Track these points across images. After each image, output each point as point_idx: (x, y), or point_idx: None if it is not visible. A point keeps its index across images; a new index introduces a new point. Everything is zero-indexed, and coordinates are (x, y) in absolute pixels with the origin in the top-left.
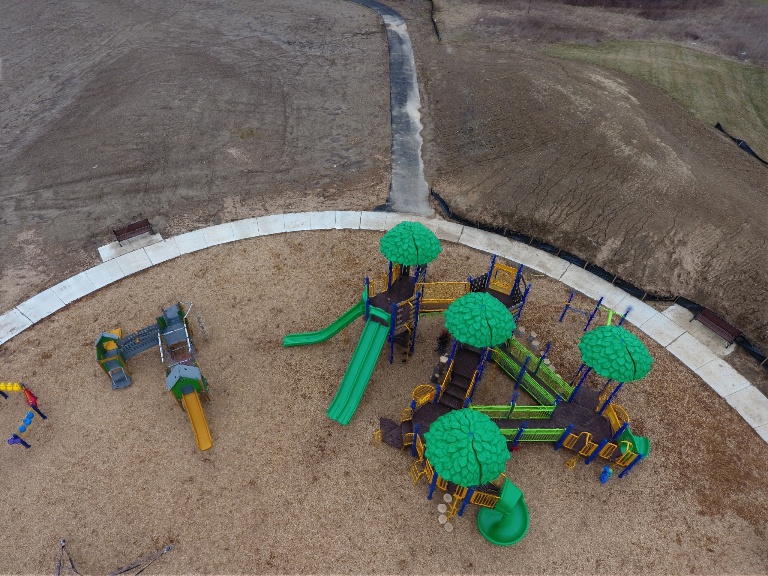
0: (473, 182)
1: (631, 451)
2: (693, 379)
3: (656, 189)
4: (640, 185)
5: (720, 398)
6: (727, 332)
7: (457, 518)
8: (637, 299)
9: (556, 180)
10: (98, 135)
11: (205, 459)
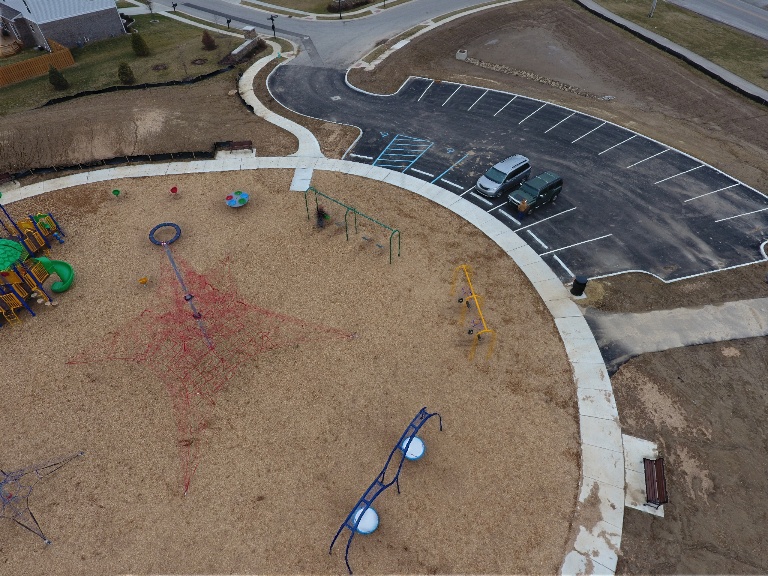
0: None
1: (46, 218)
2: (26, 200)
3: None
4: None
5: (43, 194)
6: (4, 179)
7: None
8: None
9: None
10: None
11: None
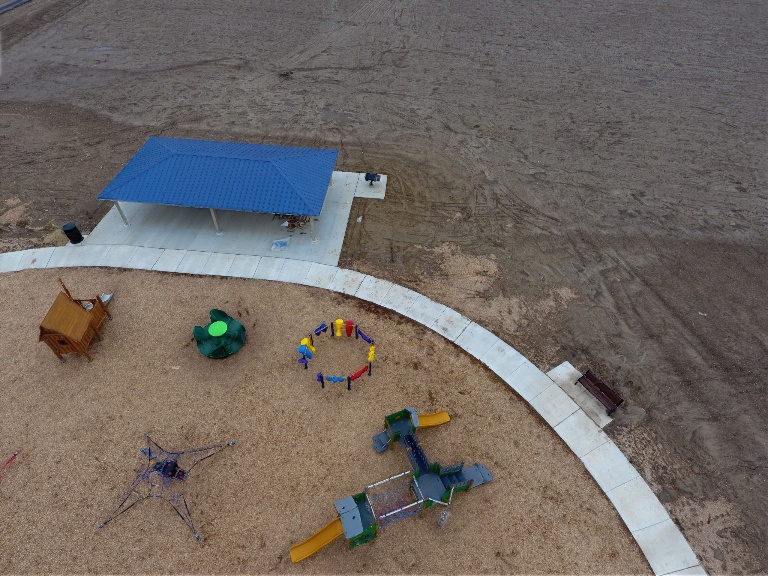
0: None
1: None
2: None
3: None
4: None
5: None
6: None
7: None
8: None
9: None
10: (766, 296)
11: (282, 557)
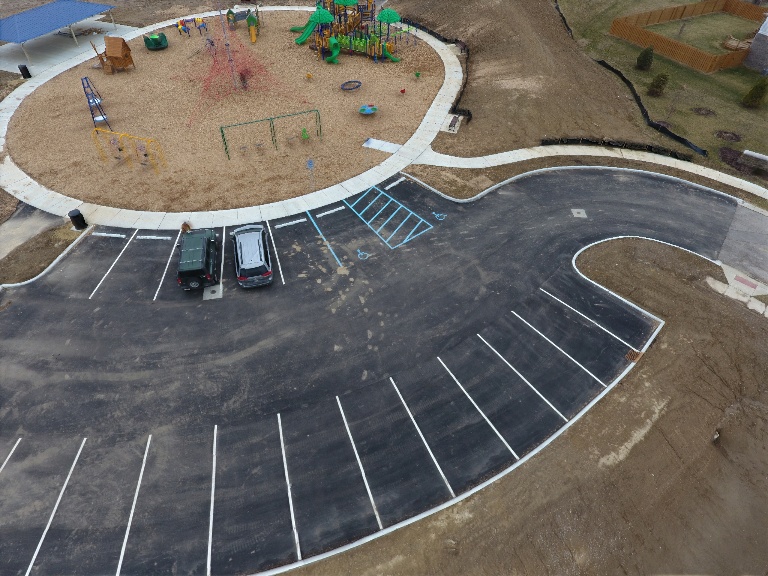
0: (402, 5)
1: None
2: (437, 56)
3: (478, 7)
4: (473, 6)
5: (441, 60)
6: (463, 47)
7: (322, 60)
8: (440, 41)
9: (438, 4)
10: None
11: (252, 44)
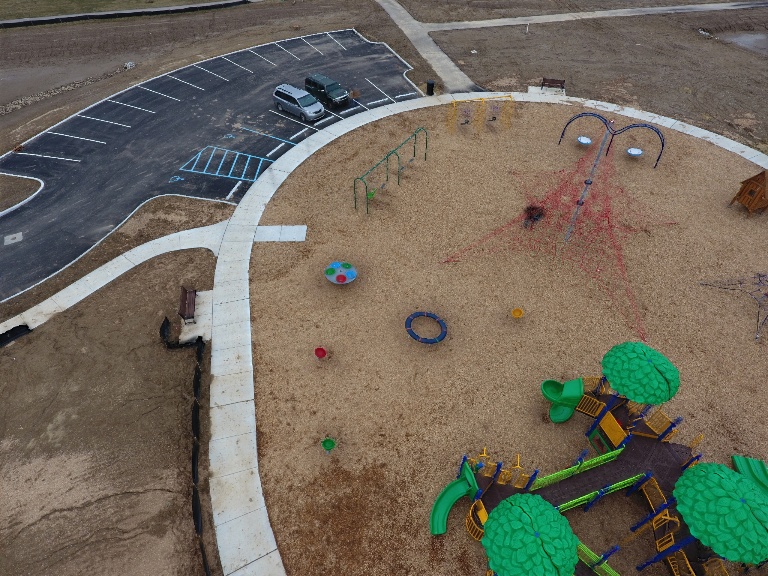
0: None
1: None
2: None
3: None
4: None
5: None
6: None
7: None
8: None
9: None
10: None
11: None
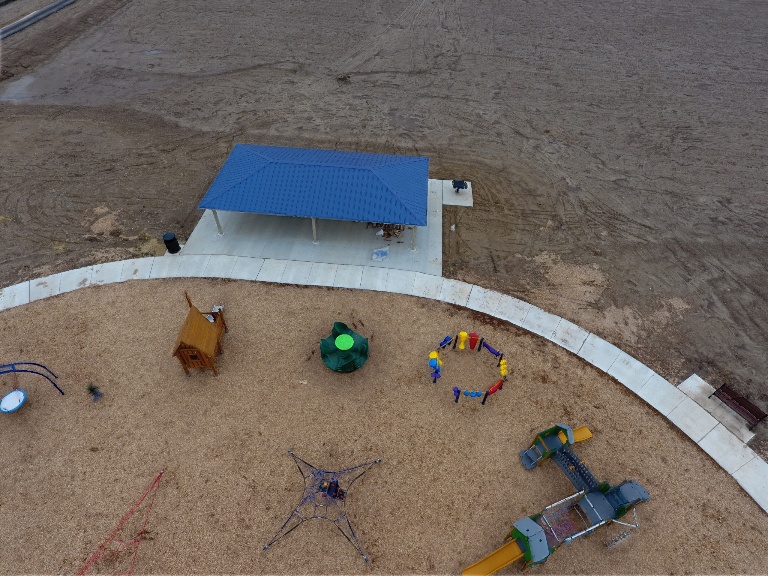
0: None
1: None
2: None
3: None
4: None
5: None
6: None
7: None
8: None
9: None
10: None
11: None
